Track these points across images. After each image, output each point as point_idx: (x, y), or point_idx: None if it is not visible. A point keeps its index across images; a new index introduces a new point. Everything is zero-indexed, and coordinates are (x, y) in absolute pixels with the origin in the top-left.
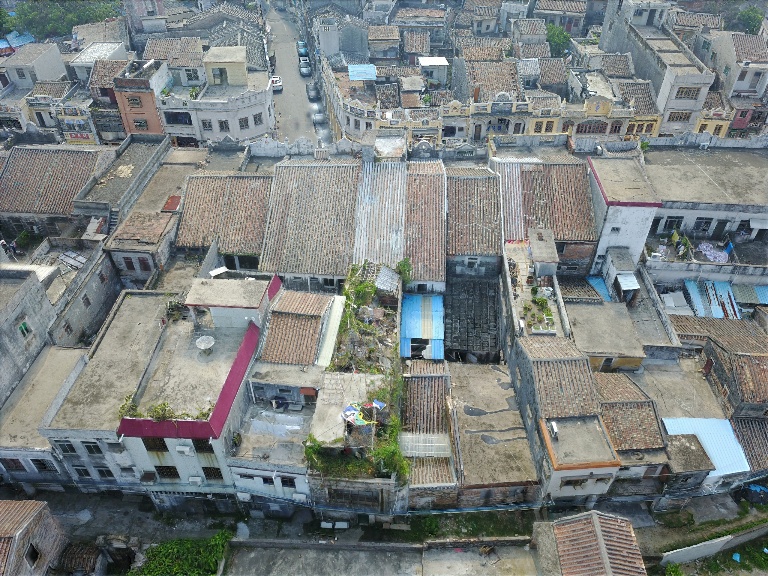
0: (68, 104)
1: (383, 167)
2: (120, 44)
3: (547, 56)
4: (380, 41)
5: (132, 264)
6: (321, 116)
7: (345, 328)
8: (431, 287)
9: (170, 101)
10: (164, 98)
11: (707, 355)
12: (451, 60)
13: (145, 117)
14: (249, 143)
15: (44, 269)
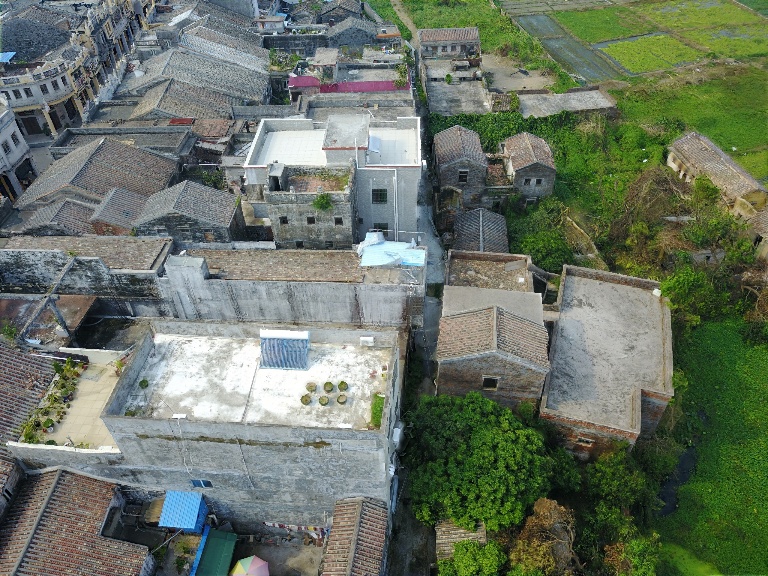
0: None
1: (185, 40)
2: None
3: None
4: None
5: None
6: None
7: None
8: None
9: None
10: None
11: (327, 22)
12: None
13: None
14: (98, 99)
15: None
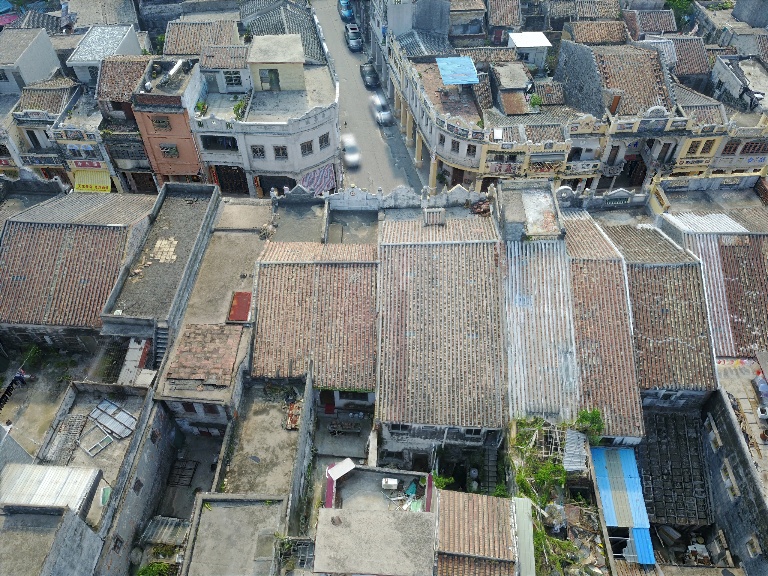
0: (70, 126)
1: (534, 249)
2: (129, 29)
3: (672, 29)
4: (461, 12)
5: (193, 407)
6: (388, 115)
7: (541, 563)
8: (620, 440)
9: (209, 122)
10: (201, 119)
11: None
12: (545, 33)
13: (175, 142)
14: (328, 195)
15: (78, 477)
